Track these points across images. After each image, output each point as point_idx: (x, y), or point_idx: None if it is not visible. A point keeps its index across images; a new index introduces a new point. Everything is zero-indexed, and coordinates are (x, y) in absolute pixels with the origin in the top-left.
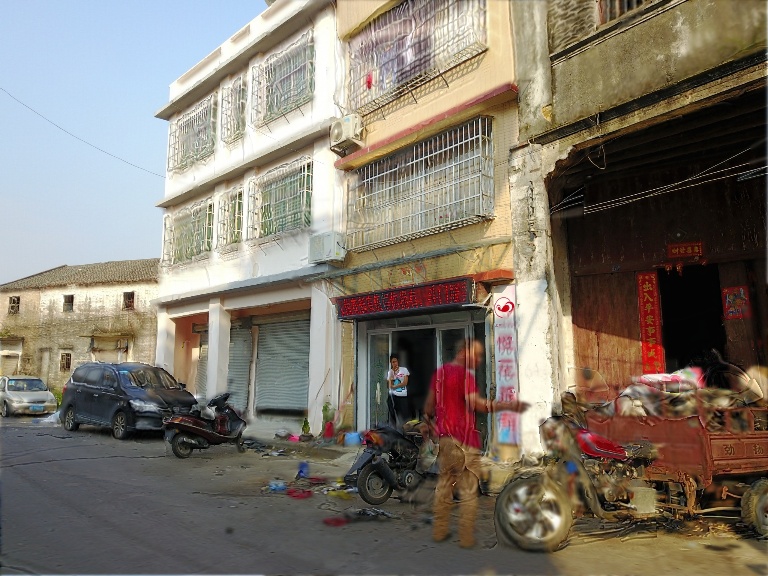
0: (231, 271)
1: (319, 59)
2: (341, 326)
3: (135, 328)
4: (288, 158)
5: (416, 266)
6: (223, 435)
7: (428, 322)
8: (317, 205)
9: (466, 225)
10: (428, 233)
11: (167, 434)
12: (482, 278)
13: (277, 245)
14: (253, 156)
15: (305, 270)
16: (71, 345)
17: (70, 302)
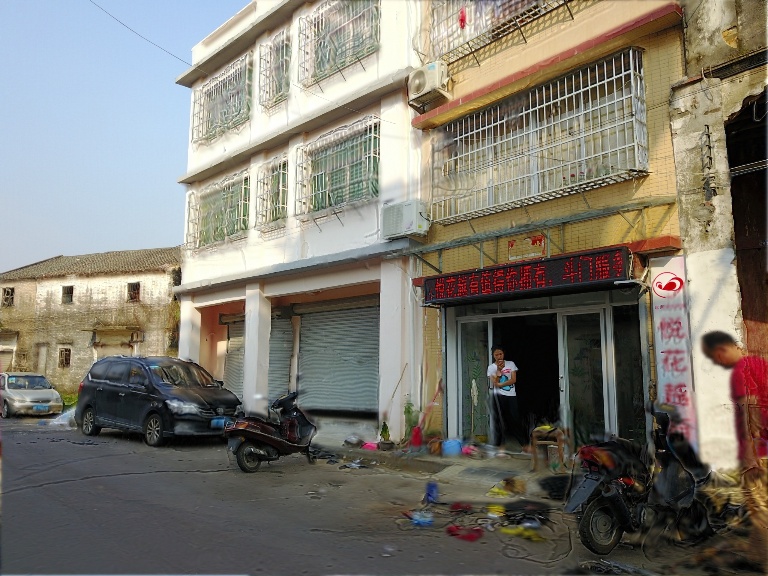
0: (272, 252)
1: (386, 3)
2: (422, 313)
3: (141, 321)
4: (345, 120)
5: (553, 233)
6: (293, 443)
7: (546, 306)
8: (387, 172)
9: (605, 185)
10: (553, 196)
11: (231, 443)
12: (639, 248)
13: (337, 219)
14: (303, 119)
15: (376, 247)
16: (71, 340)
17: (69, 293)
